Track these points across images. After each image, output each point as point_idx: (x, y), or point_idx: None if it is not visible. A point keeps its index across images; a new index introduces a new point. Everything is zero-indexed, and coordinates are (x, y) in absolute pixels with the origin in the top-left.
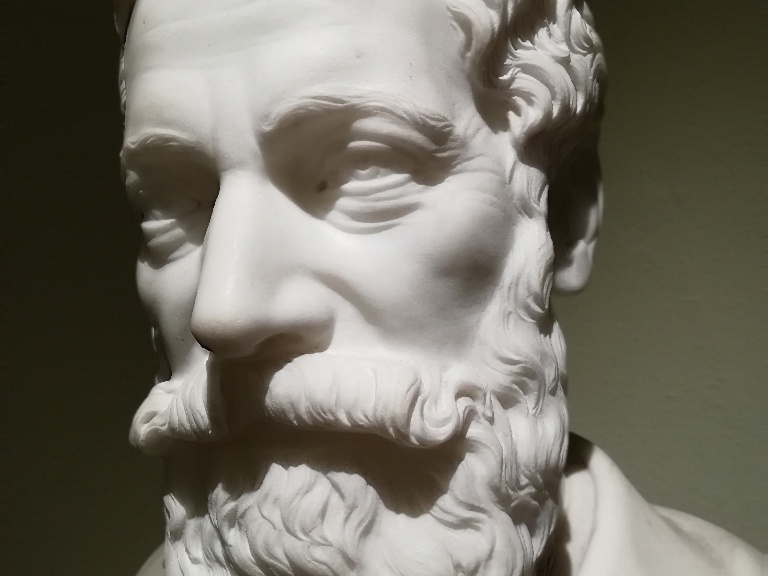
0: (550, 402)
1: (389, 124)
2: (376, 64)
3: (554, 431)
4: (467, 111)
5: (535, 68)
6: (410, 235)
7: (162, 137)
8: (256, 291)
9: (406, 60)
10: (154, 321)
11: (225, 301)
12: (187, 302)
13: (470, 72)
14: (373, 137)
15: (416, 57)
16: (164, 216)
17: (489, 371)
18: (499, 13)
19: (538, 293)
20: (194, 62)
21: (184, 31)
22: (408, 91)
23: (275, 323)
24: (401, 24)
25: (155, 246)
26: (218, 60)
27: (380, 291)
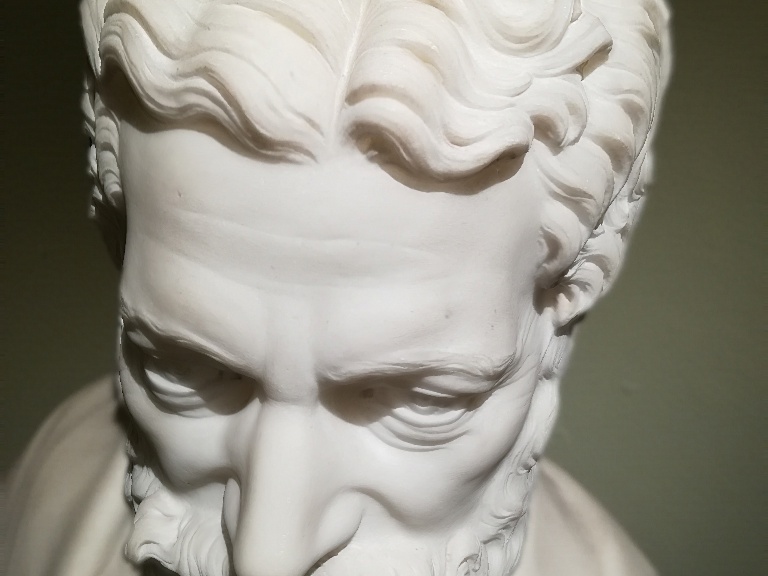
0: (520, 523)
1: (463, 381)
2: (463, 320)
3: (518, 548)
4: (526, 313)
5: (599, 257)
6: (452, 459)
7: (201, 347)
8: (305, 540)
9: (492, 307)
10: (149, 442)
11: (278, 562)
12: (203, 468)
13: (540, 278)
14: (443, 390)
15: (501, 298)
16: (181, 382)
17: (483, 526)
18: (590, 231)
19: (539, 454)
20: (250, 278)
21: (241, 239)
22: (488, 345)
23: (318, 558)
24: (495, 266)
25: (165, 401)
26: (282, 287)
27: (413, 504)
